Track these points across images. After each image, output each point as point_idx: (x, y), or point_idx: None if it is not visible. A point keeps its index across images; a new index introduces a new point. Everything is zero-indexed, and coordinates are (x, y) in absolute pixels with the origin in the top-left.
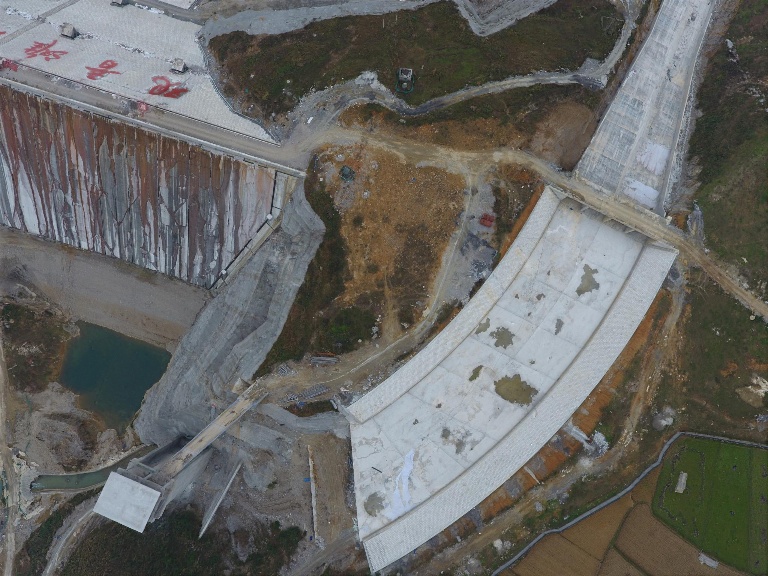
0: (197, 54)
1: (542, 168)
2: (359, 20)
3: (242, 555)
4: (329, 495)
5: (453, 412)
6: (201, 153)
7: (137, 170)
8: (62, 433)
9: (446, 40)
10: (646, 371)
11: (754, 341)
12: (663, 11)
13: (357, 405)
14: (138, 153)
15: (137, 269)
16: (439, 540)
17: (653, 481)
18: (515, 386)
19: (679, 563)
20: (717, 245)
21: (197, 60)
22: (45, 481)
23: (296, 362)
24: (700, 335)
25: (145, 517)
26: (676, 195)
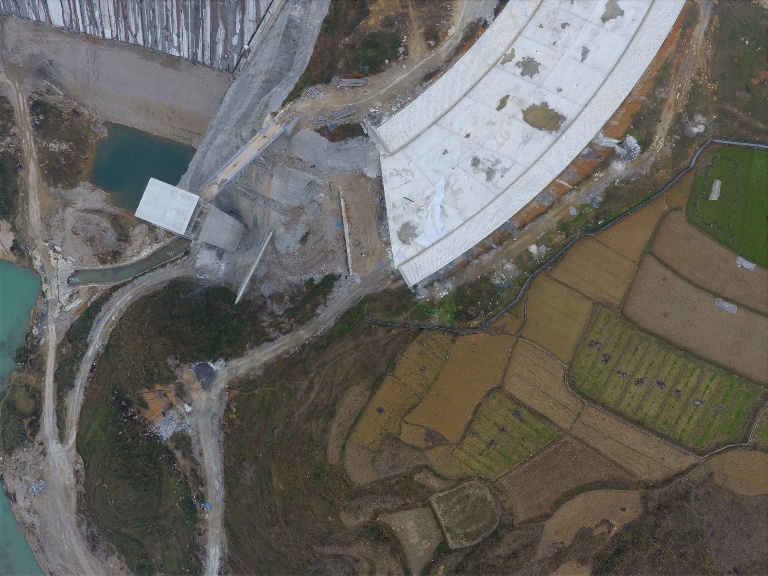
0: None
1: None
2: None
3: (278, 311)
4: (362, 230)
5: (482, 141)
6: None
7: None
8: (96, 226)
9: None
10: (676, 79)
11: None
12: None
13: (387, 127)
14: None
15: (161, 56)
16: (474, 251)
17: (687, 186)
18: (543, 114)
19: (716, 267)
20: None
21: None
22: (81, 276)
23: (325, 85)
24: (729, 45)
25: (186, 220)
26: None
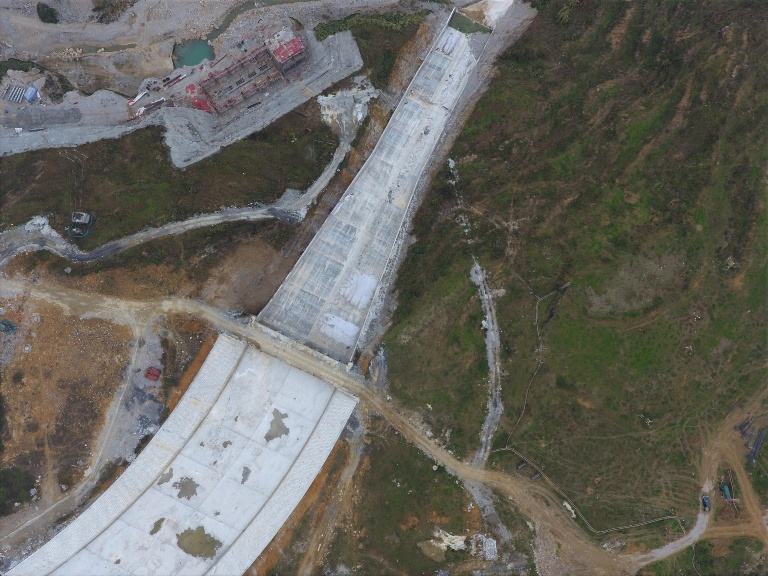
0: None
1: (214, 316)
2: (50, 154)
3: None
4: None
5: (132, 568)
6: None
7: None
8: None
9: (142, 172)
10: (318, 529)
11: (437, 492)
12: (394, 126)
13: (17, 570)
14: None
15: None
16: None
17: None
18: (198, 539)
19: None
20: (400, 391)
21: None
22: None
23: None
24: (380, 487)
25: None
26: (372, 333)
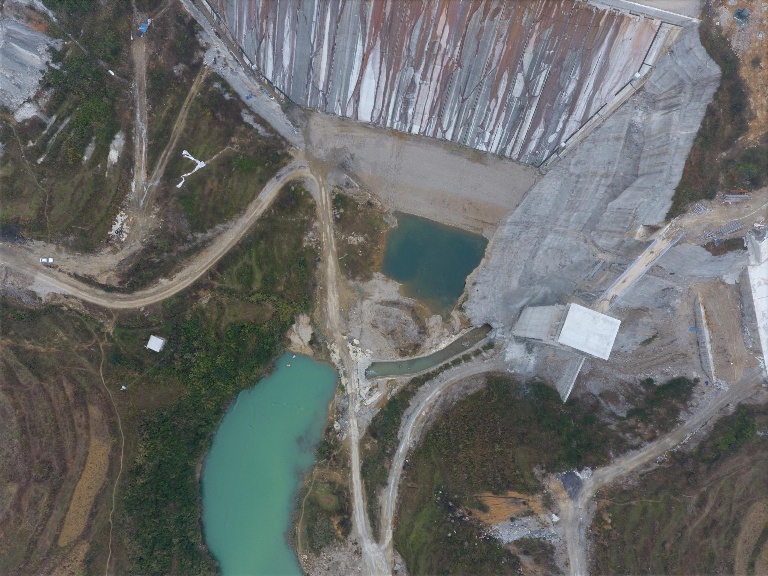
0: None
1: None
2: None
3: (620, 412)
4: (728, 338)
5: None
6: (585, 9)
7: (506, 36)
8: (396, 319)
9: None
10: None
11: None
12: None
13: None
14: (514, 16)
15: (467, 151)
16: None
17: None
18: None
19: None
20: None
21: None
22: (377, 368)
23: (710, 201)
24: None
25: (609, 345)
26: None
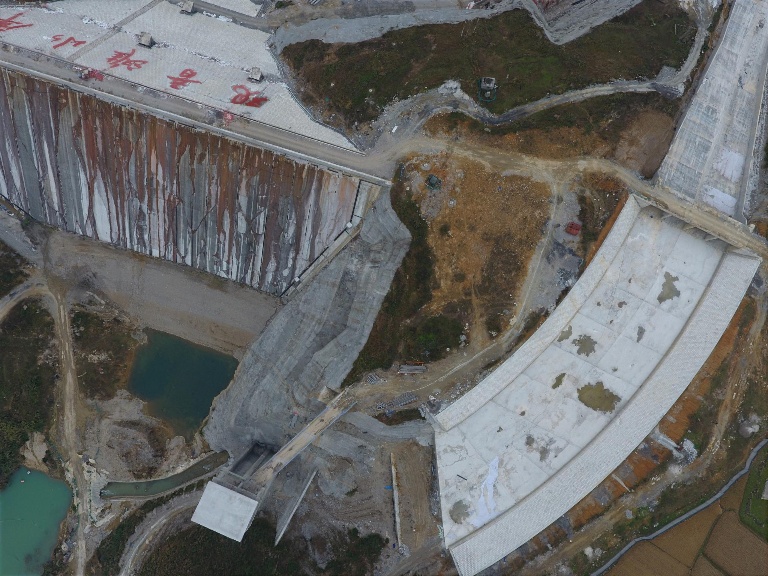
0: (270, 62)
1: (626, 176)
2: (437, 29)
3: (321, 562)
4: (413, 503)
5: (537, 420)
6: (285, 162)
7: (217, 179)
8: (132, 440)
9: (523, 48)
10: (732, 378)
11: None
12: (732, 18)
13: (445, 413)
14: (220, 162)
15: (208, 277)
16: (529, 548)
17: (741, 488)
18: (598, 393)
19: (767, 570)
20: None
21: (272, 68)
22: (114, 488)
23: (385, 371)
24: None
25: (243, 526)
26: (755, 202)
